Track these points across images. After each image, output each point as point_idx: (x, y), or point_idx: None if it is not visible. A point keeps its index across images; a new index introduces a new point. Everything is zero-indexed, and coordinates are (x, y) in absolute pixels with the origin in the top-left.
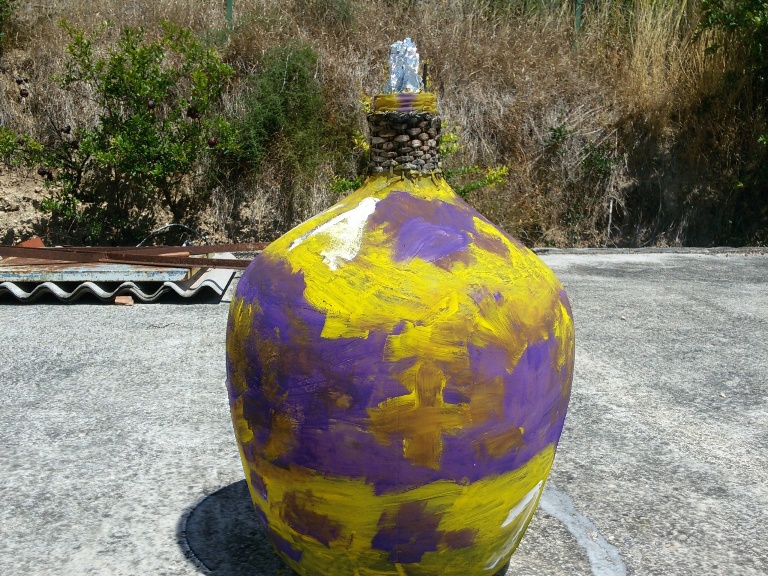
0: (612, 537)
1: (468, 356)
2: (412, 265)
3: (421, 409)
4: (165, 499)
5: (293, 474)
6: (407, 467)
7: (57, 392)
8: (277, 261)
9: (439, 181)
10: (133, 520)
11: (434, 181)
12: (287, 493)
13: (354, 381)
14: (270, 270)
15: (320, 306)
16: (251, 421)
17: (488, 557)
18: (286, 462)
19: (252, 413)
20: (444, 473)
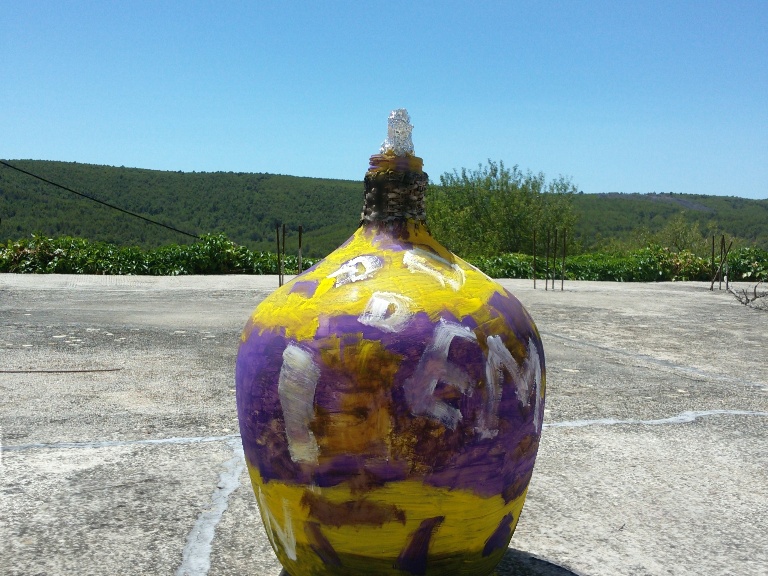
0: None
1: None
2: None
3: None
4: None
5: None
6: None
7: None
8: None
9: None
10: None
11: None
12: None
13: None
14: None
15: None
16: None
17: None
18: None
19: None
20: None
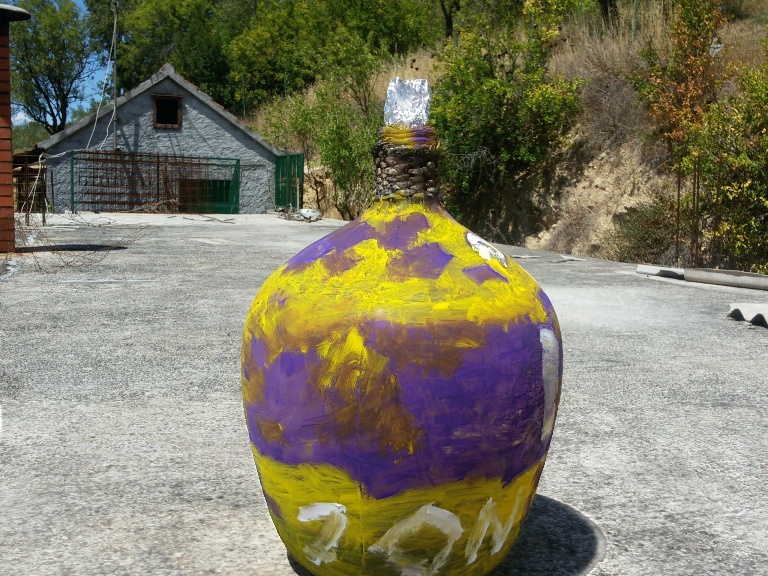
0: None
1: (251, 343)
2: None
3: None
4: None
5: None
6: None
7: (658, 410)
8: None
9: (389, 206)
10: None
11: (380, 205)
12: None
13: None
14: None
15: None
16: None
17: (303, 546)
18: None
19: None
20: None
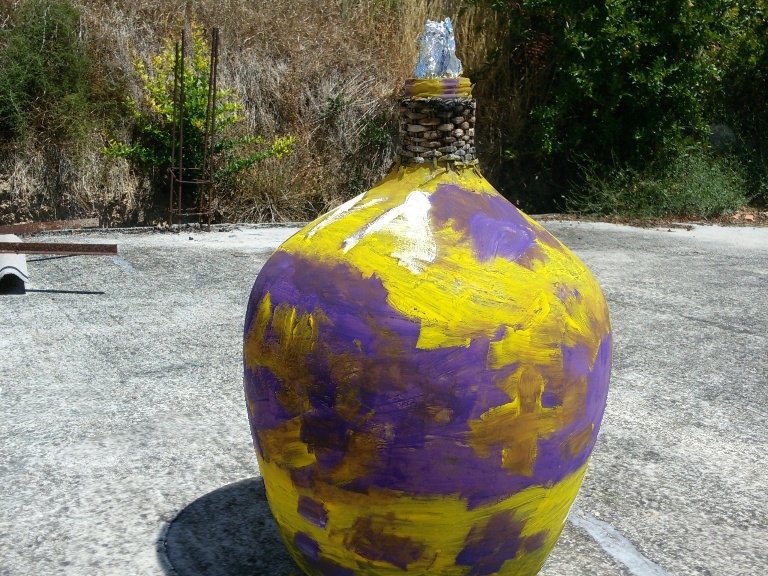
0: (598, 513)
1: (562, 358)
2: (497, 265)
3: (522, 416)
4: (123, 534)
5: (372, 498)
6: (503, 477)
7: None
8: (334, 264)
9: None
10: (103, 564)
11: (476, 173)
12: (360, 518)
13: (456, 393)
14: (329, 275)
15: (411, 314)
16: (314, 444)
17: (547, 555)
18: (364, 486)
19: (317, 435)
20: (534, 479)
